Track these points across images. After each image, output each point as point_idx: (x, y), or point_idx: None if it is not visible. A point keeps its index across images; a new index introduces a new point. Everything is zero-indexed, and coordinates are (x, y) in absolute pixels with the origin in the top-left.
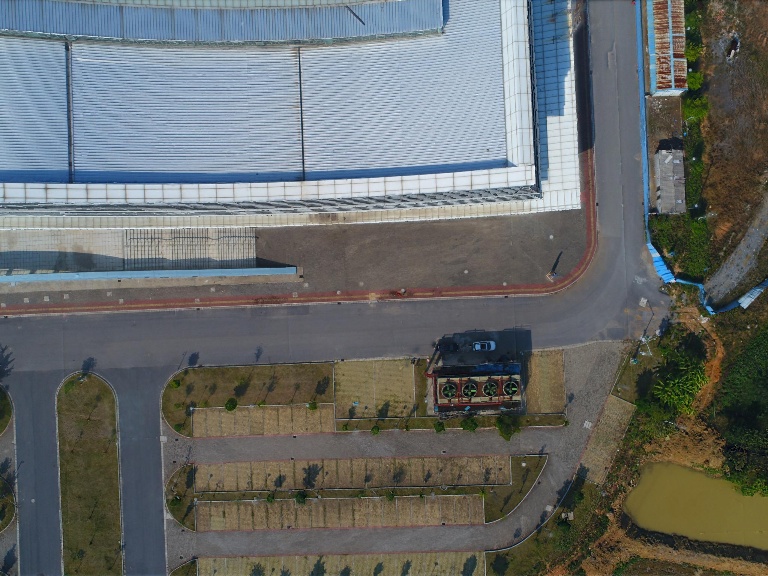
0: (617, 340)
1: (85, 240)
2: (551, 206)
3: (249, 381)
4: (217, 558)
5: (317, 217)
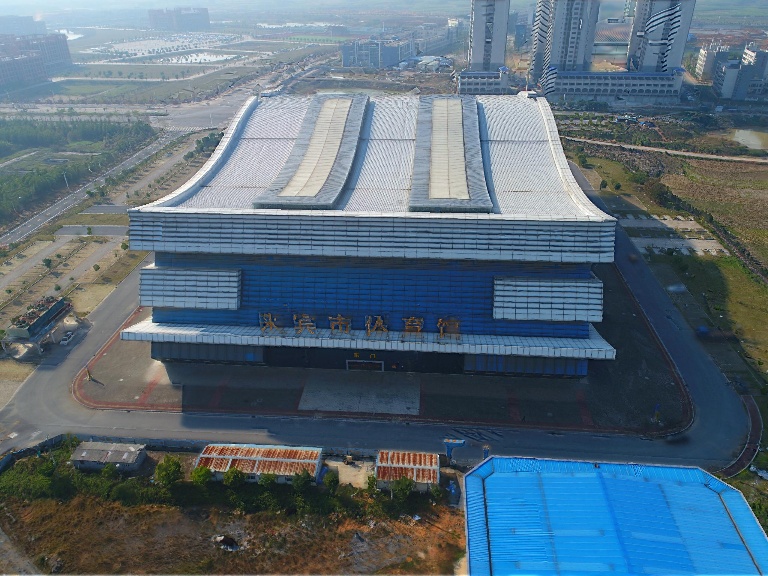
0: None
1: None
2: None
3: (134, 258)
4: (46, 247)
5: None
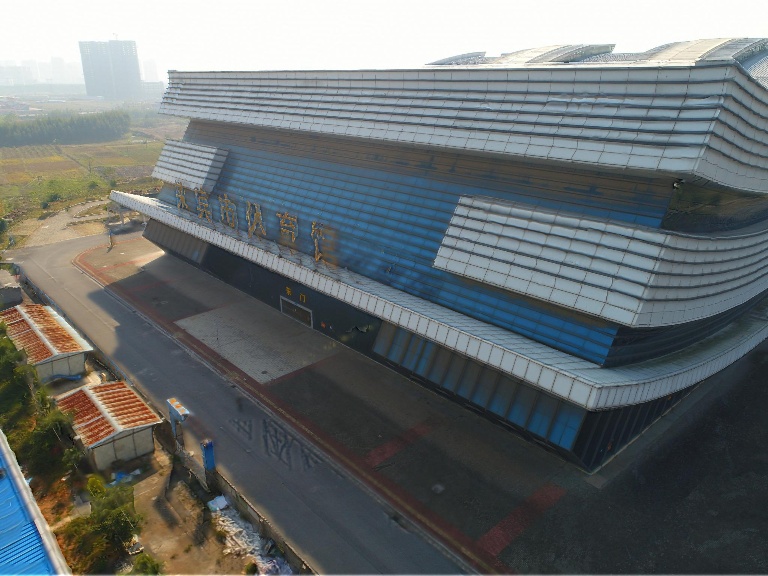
0: None
1: None
2: None
3: None
4: None
5: None
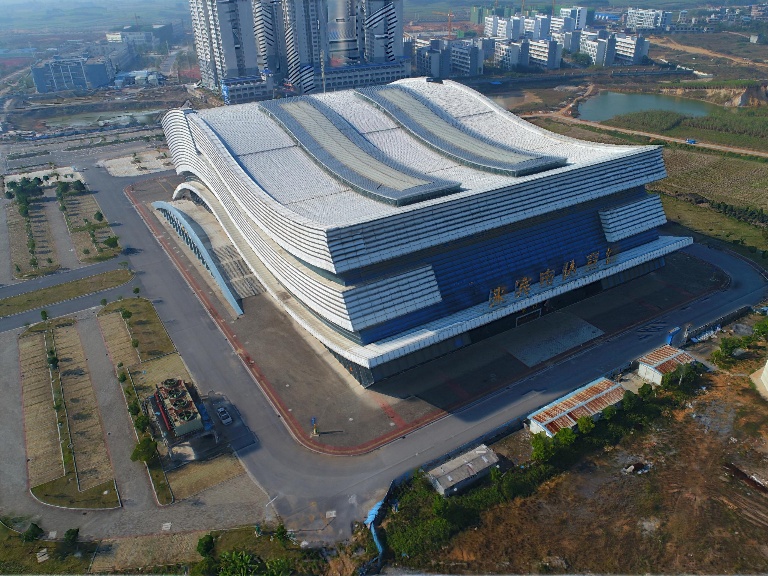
0: (277, 511)
1: (218, 238)
2: None
3: (148, 323)
4: None
5: (281, 294)
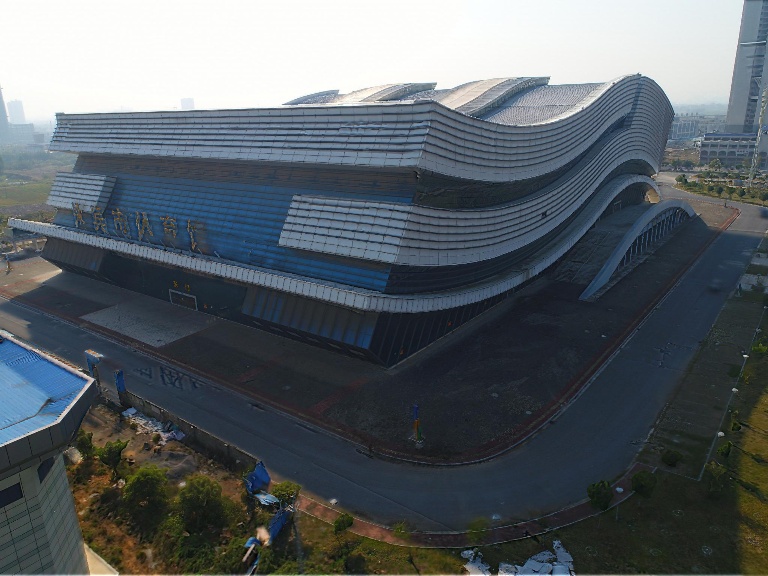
0: None
1: None
2: None
3: None
4: None
5: None
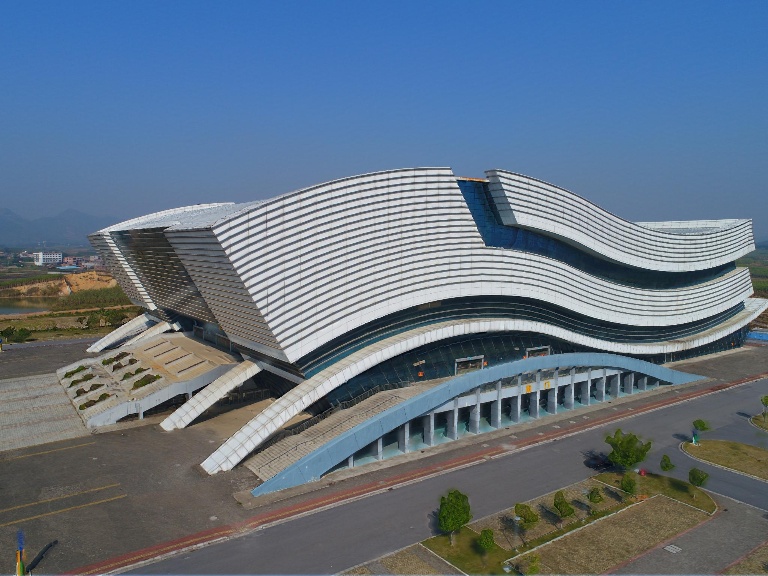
0: None
1: None
2: (760, 305)
3: None
4: None
5: None
